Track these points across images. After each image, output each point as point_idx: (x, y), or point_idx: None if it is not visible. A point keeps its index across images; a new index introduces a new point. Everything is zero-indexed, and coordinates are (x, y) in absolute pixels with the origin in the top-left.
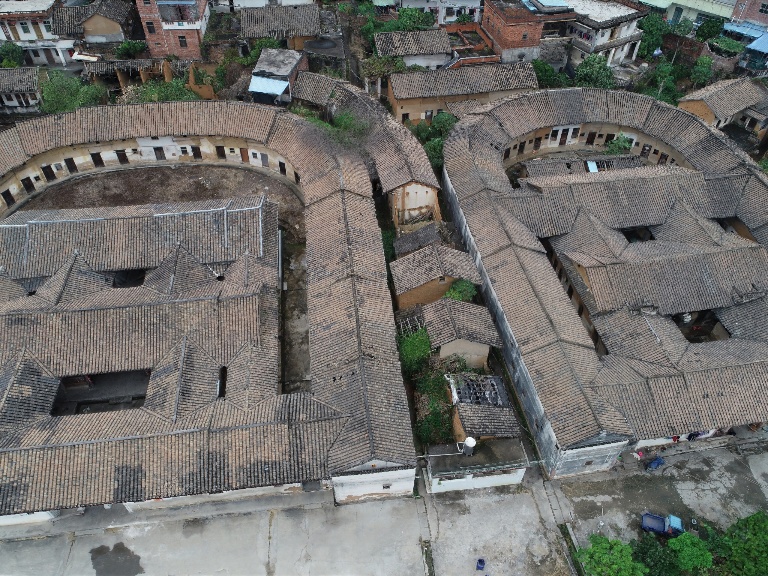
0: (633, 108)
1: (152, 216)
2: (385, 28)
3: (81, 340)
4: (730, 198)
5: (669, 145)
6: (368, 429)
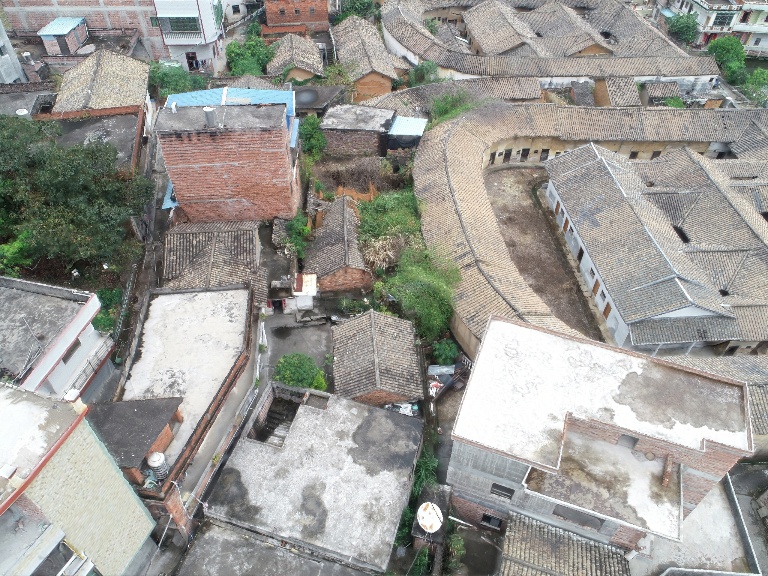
0: (413, 1)
1: (627, 198)
2: (251, 70)
3: (767, 235)
4: (504, 2)
5: (440, 8)
6: (762, 110)
